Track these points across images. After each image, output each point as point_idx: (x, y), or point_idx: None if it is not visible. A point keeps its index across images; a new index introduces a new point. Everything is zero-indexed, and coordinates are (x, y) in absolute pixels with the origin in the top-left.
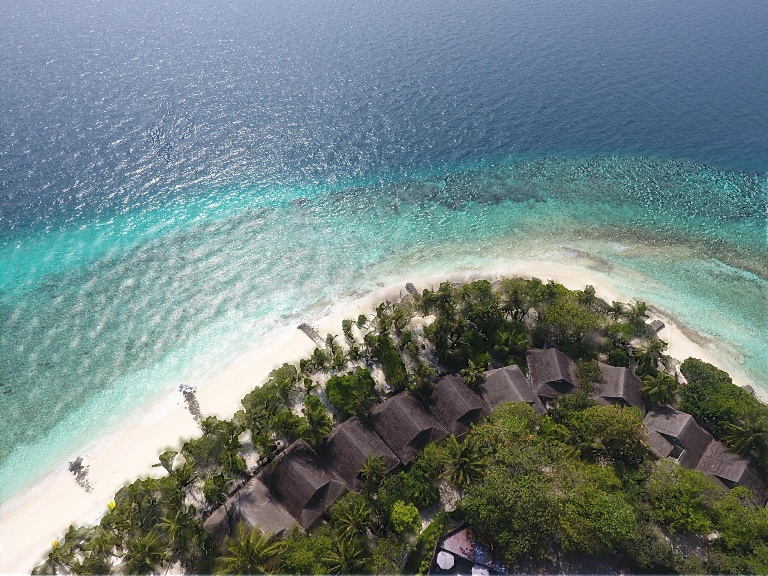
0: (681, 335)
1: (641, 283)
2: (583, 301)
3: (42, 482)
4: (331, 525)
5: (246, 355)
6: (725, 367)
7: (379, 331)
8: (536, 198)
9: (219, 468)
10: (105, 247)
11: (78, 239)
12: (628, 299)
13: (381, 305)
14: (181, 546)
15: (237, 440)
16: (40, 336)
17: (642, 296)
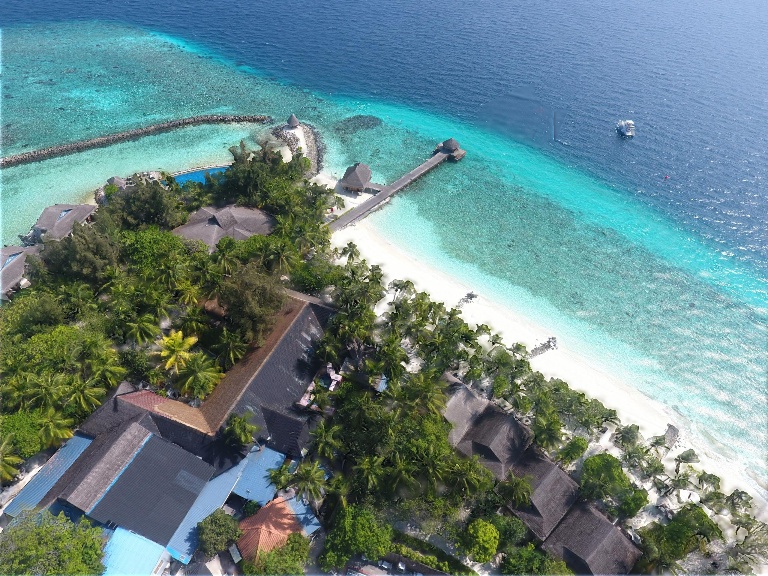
0: None
1: None
2: None
3: (457, 283)
4: (462, 462)
5: (608, 381)
6: None
7: (701, 495)
8: None
9: (492, 378)
10: (665, 250)
11: (661, 231)
12: None
13: (744, 492)
14: (427, 353)
15: (519, 385)
16: (558, 245)
17: None
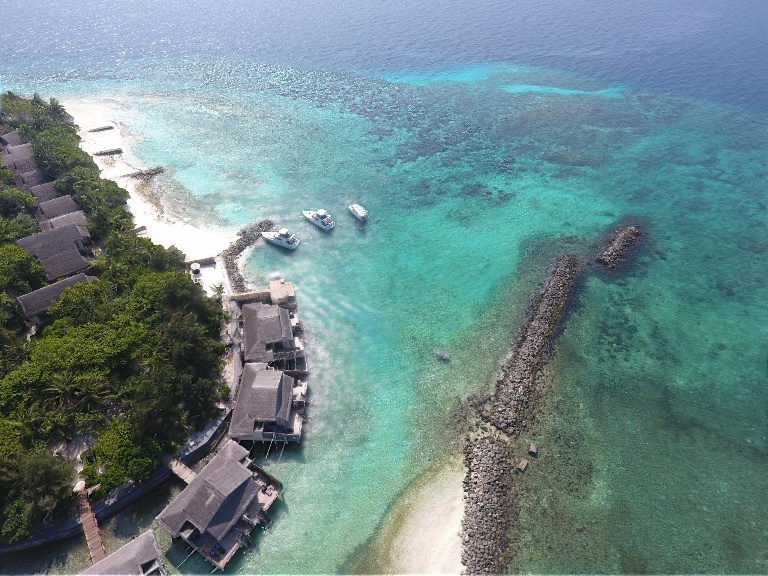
0: (117, 132)
1: (132, 114)
2: (32, 102)
3: None
4: None
5: None
6: (123, 144)
7: None
8: (128, 78)
9: None
10: None
11: None
12: (110, 119)
13: None
14: None
15: None
16: None
17: (122, 118)
